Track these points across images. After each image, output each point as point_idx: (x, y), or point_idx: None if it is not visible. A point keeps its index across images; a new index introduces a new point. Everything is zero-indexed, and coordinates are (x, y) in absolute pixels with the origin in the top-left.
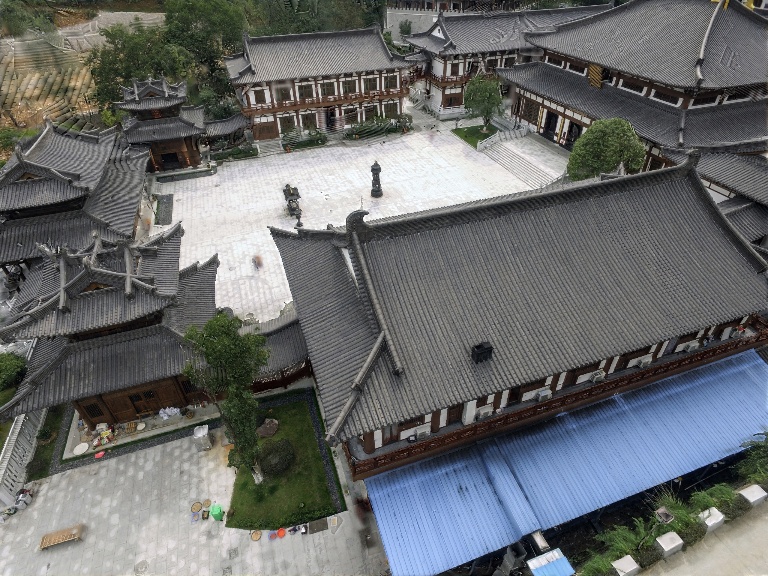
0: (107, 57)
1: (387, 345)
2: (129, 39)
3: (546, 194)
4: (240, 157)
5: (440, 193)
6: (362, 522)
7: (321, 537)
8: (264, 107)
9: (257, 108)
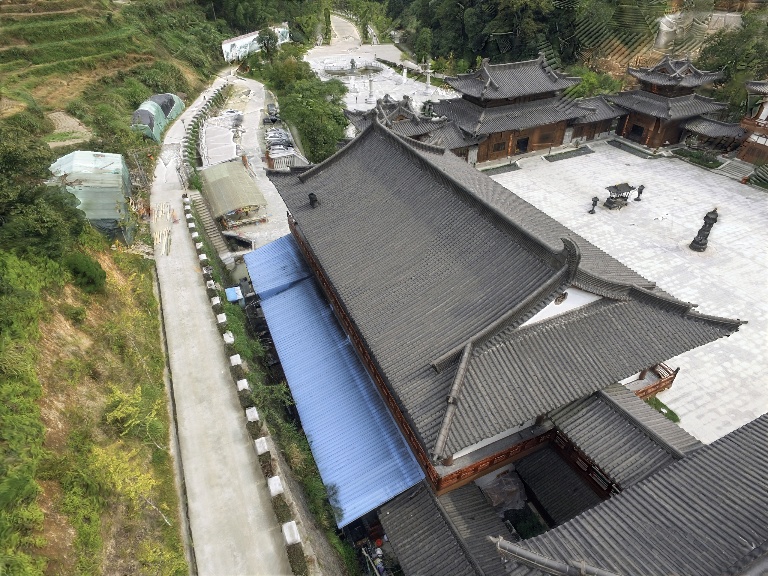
0: (726, 38)
1: None
2: (750, 25)
3: (446, 174)
4: (694, 161)
5: (756, 296)
6: None
7: None
8: (767, 126)
9: (759, 124)
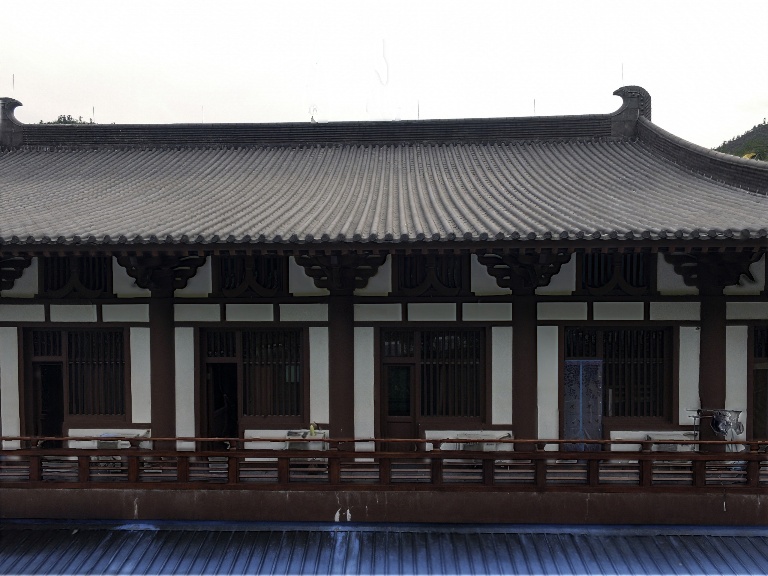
0: None
1: None
2: None
3: None
4: None
5: None
6: None
7: None
8: None
9: None
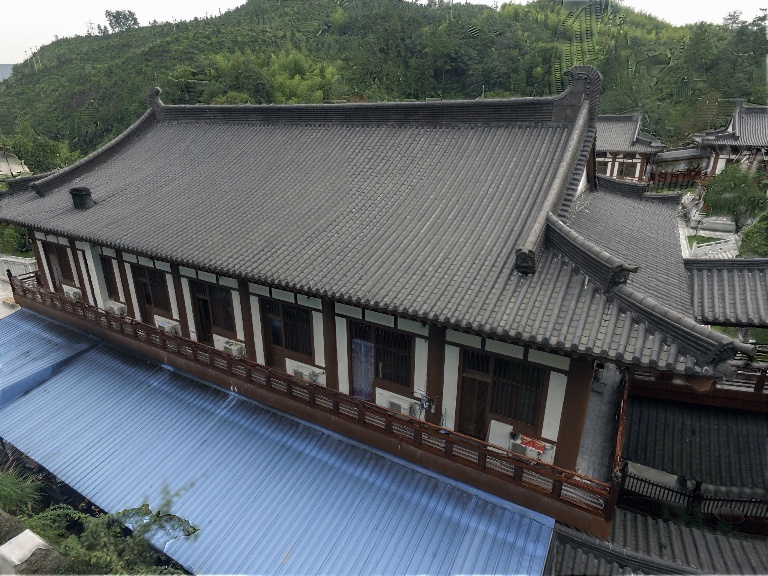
0: None
1: None
2: None
3: (319, 106)
4: None
5: None
6: None
7: None
8: None
9: None
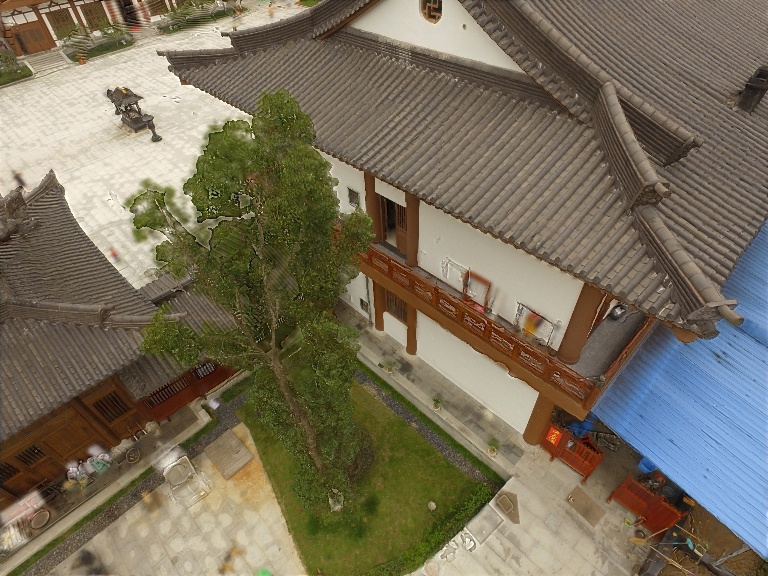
0: None
1: (633, 106)
2: None
3: None
4: (3, 82)
5: None
6: (547, 483)
7: (502, 539)
8: None
9: None
